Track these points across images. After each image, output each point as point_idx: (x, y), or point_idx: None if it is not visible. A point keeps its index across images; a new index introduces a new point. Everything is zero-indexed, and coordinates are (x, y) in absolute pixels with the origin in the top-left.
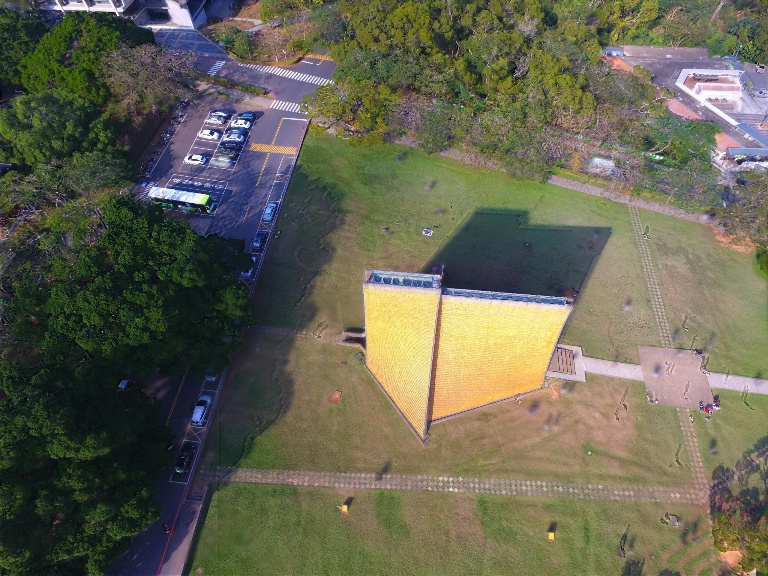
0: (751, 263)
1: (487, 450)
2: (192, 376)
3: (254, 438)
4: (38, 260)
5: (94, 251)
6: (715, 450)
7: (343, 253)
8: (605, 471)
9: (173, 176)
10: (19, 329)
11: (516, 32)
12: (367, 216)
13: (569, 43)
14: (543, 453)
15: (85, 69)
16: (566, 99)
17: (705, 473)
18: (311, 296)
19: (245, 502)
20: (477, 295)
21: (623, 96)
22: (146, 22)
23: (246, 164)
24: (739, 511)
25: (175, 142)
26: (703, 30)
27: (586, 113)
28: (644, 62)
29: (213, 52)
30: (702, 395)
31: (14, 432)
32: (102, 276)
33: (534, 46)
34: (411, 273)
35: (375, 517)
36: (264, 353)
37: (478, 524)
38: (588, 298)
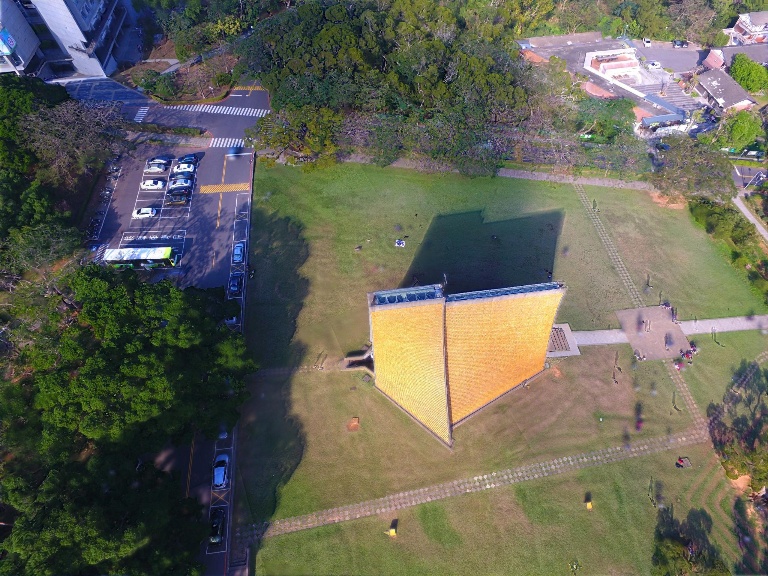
0: (687, 217)
1: (511, 440)
2: (205, 438)
3: (283, 486)
4: (7, 354)
5: (76, 331)
6: (703, 390)
7: (323, 280)
8: (618, 433)
9: (124, 234)
10: (8, 434)
11: (436, 39)
12: (337, 238)
13: (488, 43)
14: (561, 430)
15: (1, 138)
16: (500, 96)
17: (701, 413)
18: (303, 329)
19: (291, 554)
20: (478, 296)
21: (547, 86)
22: (50, 77)
23: (200, 208)
24: (736, 439)
25: (117, 198)
26: (593, 15)
27: (520, 106)
28: (552, 51)
29: (133, 98)
30: (680, 343)
31: (43, 548)
32: (92, 356)
33: (458, 51)
34: (413, 288)
35: (424, 533)
36: (270, 397)
37: (521, 513)
38: (562, 277)
